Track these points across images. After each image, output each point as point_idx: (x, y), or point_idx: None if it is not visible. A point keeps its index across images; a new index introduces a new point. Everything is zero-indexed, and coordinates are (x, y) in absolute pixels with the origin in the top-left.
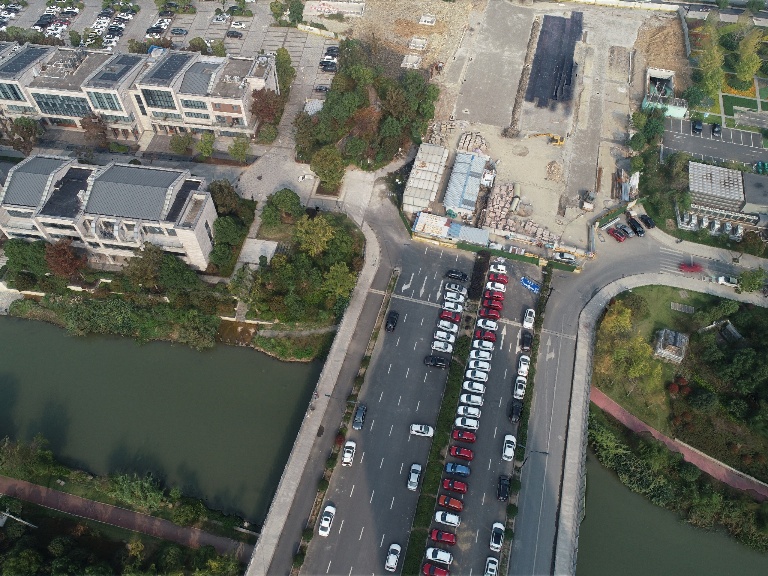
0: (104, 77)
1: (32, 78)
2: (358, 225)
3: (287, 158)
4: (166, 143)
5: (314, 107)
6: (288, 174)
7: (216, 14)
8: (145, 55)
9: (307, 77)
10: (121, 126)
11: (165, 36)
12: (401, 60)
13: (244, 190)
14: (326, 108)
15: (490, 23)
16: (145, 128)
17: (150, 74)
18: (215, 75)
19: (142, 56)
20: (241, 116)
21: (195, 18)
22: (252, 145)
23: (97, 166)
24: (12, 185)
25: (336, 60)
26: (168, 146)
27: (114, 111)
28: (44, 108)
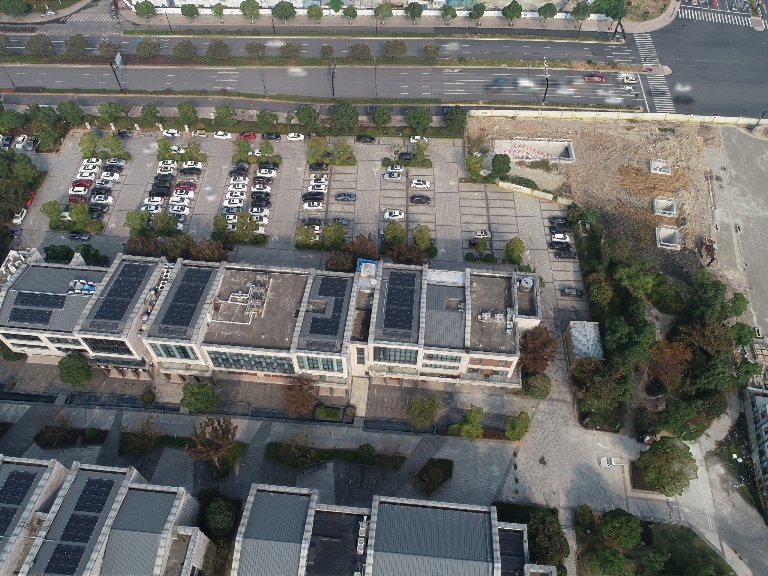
0: (316, 328)
1: (205, 327)
2: (717, 550)
3: (567, 420)
4: (390, 400)
5: (588, 337)
6: (580, 451)
7: (384, 165)
8: (352, 275)
9: (539, 268)
10: (332, 385)
11: (328, 204)
12: (653, 236)
13: (529, 486)
14: (614, 345)
15: (738, 167)
16: (354, 374)
17: (379, 319)
18: (470, 315)
19: (348, 276)
20: (507, 369)
21: (358, 172)
22: (511, 398)
23: (357, 509)
24: (242, 564)
25: (569, 239)
26: (395, 405)
27: (328, 372)
28: (219, 362)
